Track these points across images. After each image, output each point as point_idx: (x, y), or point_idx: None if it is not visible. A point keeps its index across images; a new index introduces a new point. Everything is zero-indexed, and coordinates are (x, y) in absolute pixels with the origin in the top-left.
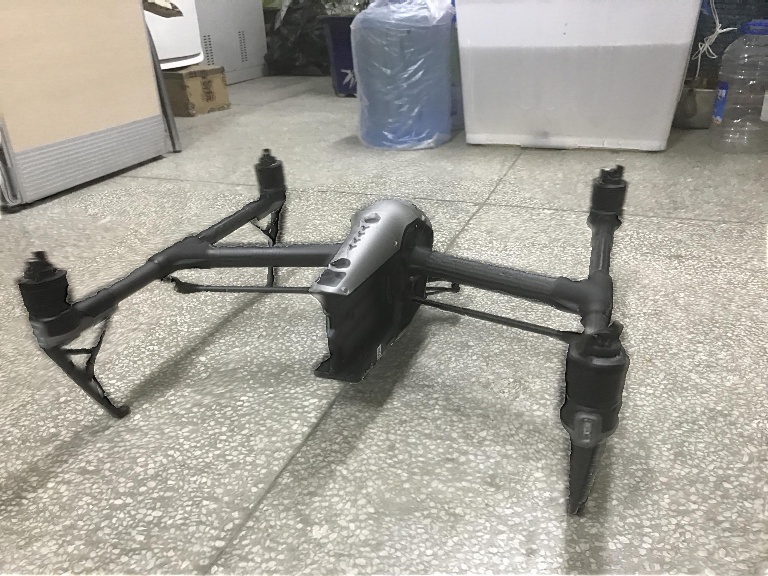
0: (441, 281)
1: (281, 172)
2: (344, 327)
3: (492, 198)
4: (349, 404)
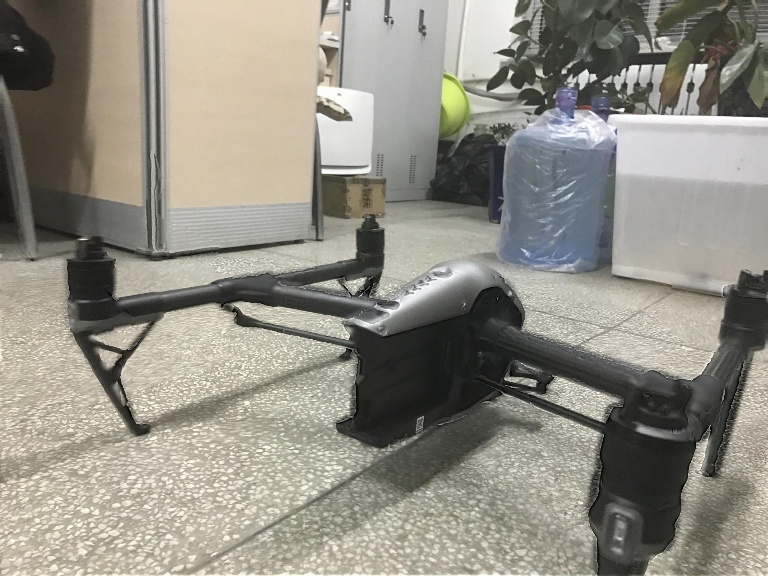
0: (526, 378)
1: (382, 239)
2: (379, 379)
3: (623, 325)
4: (375, 480)
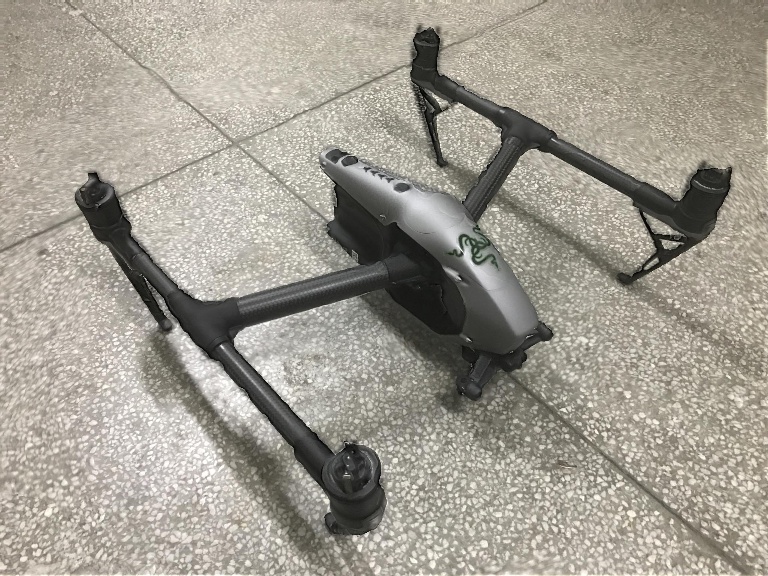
0: None
1: (698, 199)
2: (342, 200)
3: None
4: None
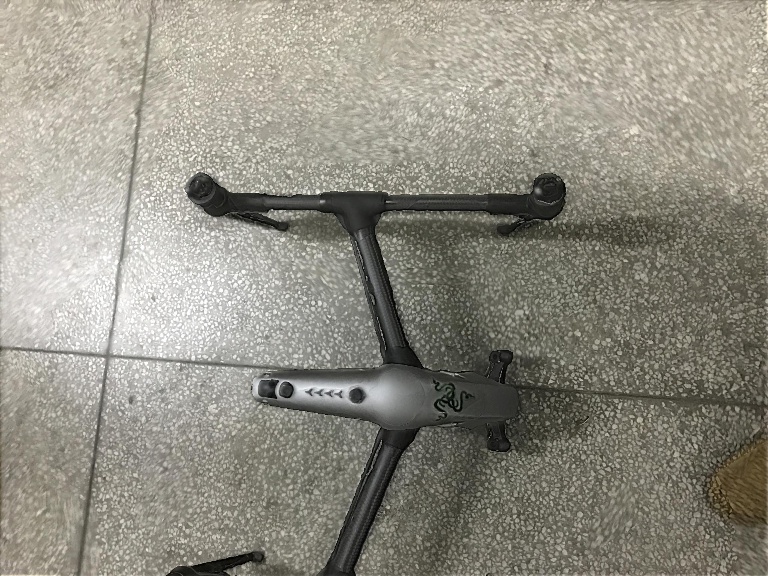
0: None
1: (549, 210)
2: None
3: None
4: None
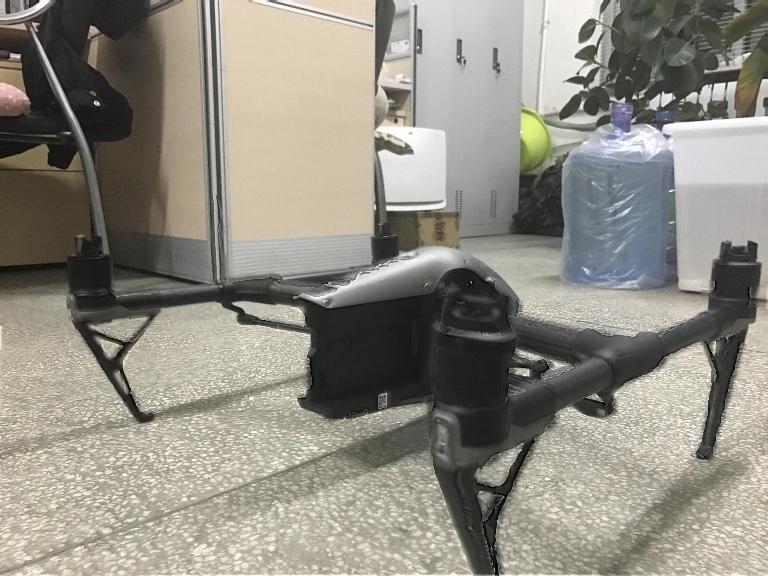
0: (520, 368)
1: (392, 245)
2: (333, 353)
3: None
4: (344, 458)
